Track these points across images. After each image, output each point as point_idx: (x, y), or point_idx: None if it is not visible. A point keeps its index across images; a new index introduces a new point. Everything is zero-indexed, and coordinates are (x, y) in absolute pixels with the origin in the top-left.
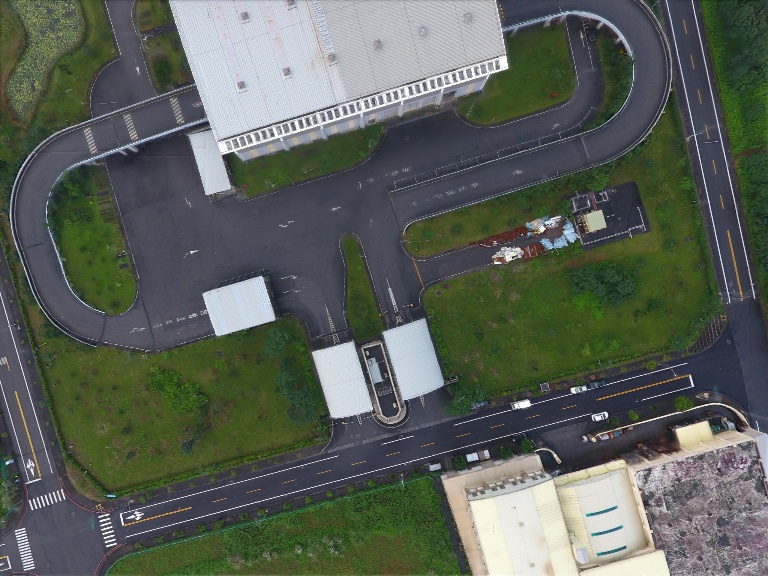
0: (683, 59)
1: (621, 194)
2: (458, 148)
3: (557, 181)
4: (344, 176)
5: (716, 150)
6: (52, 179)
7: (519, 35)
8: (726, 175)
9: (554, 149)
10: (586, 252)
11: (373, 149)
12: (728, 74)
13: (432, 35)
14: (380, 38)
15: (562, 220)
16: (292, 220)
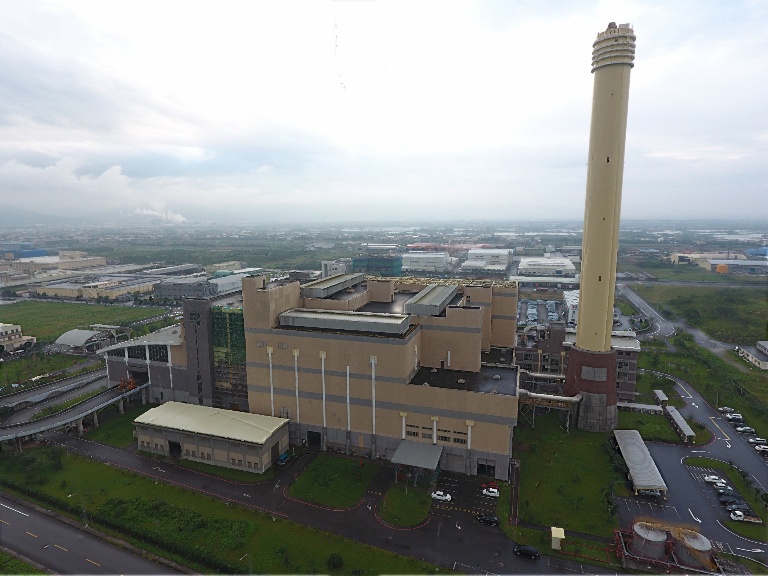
0: None
1: None
2: None
3: None
4: None
5: None
6: None
7: (99, 413)
8: None
9: None
10: None
11: None
12: None
13: None
14: None
15: None
16: None
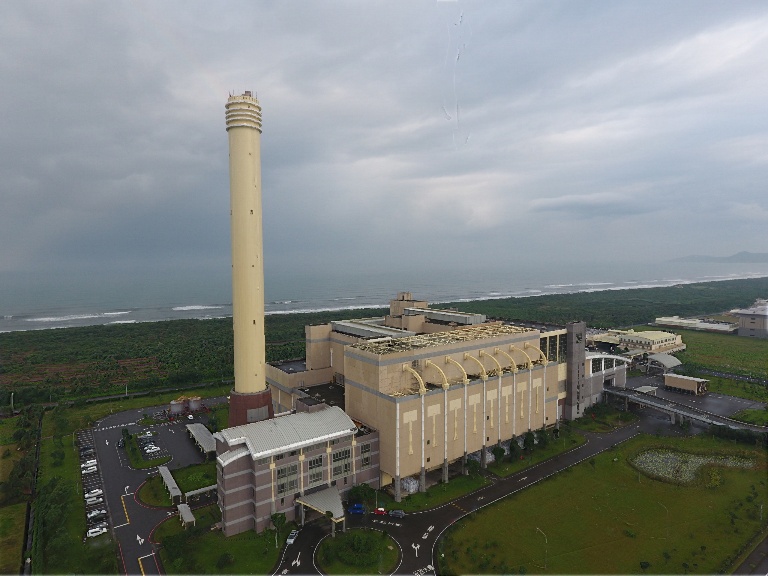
0: None
1: None
2: None
3: None
4: None
5: None
6: (755, 428)
7: None
8: None
9: None
10: None
11: None
12: None
13: None
14: None
15: None
16: None
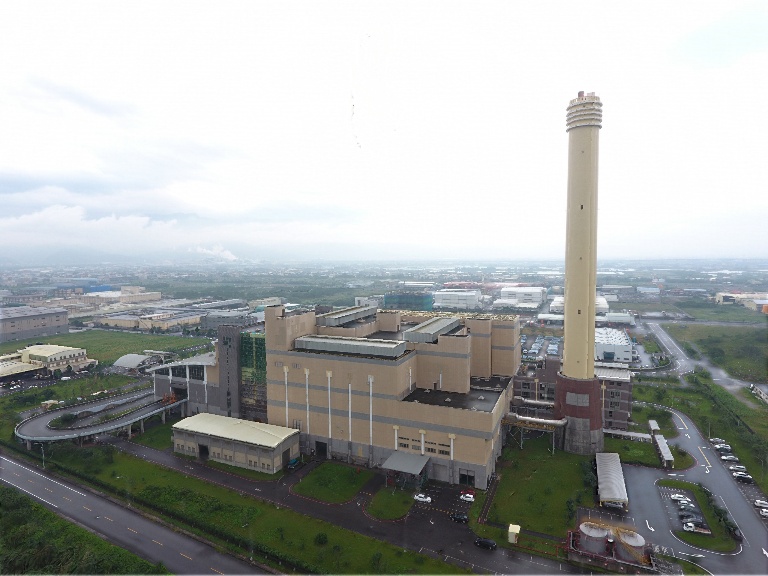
0: None
1: None
2: None
3: None
4: None
5: None
6: None
7: None
8: None
9: None
10: None
11: None
12: None
13: None
14: None
15: None
16: None
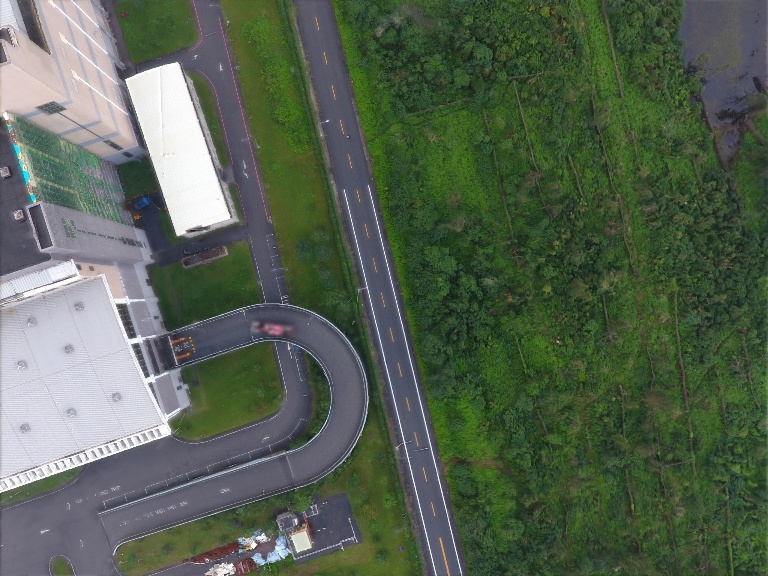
0: (390, 367)
1: (332, 506)
2: (168, 465)
3: (259, 505)
4: (52, 497)
5: (426, 457)
6: None
7: None
8: (437, 482)
9: (260, 467)
10: (299, 566)
11: (81, 469)
12: (431, 386)
13: (83, 414)
14: (28, 421)
15: (275, 534)
16: (0, 545)
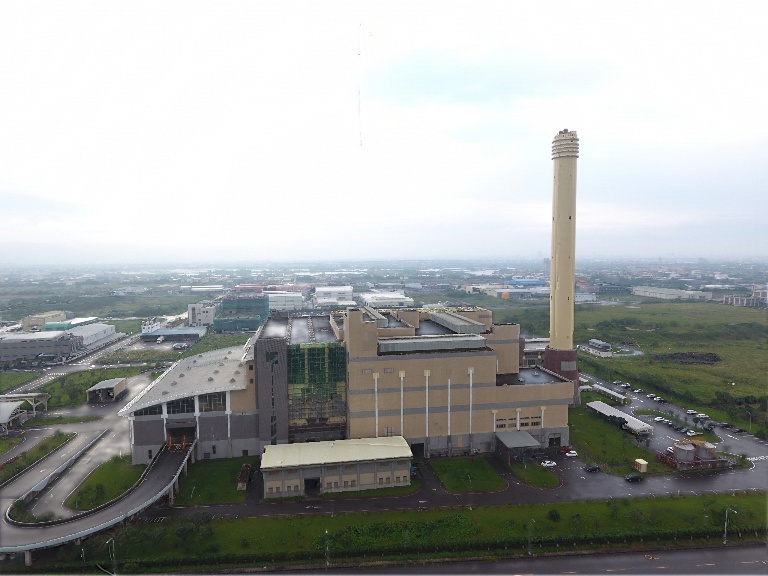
0: None
1: None
2: (101, 453)
3: None
4: None
5: None
6: None
7: None
8: None
9: None
10: None
11: None
12: None
13: None
14: None
15: None
16: None
